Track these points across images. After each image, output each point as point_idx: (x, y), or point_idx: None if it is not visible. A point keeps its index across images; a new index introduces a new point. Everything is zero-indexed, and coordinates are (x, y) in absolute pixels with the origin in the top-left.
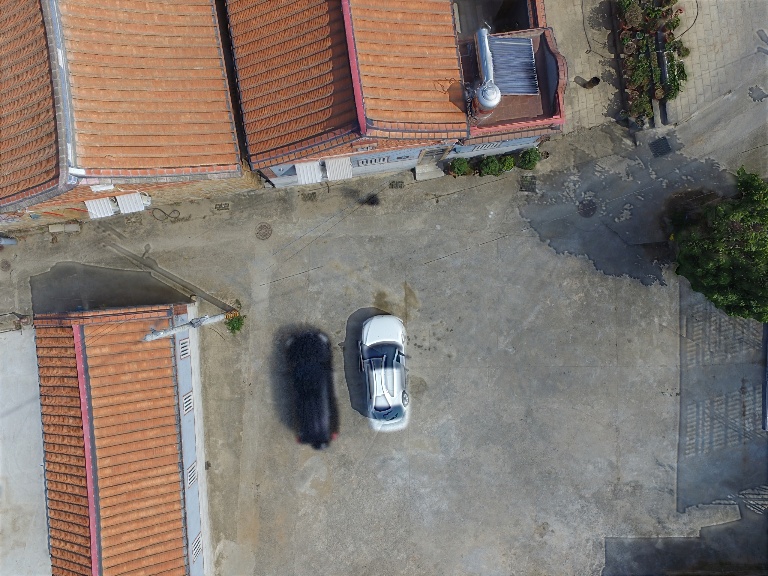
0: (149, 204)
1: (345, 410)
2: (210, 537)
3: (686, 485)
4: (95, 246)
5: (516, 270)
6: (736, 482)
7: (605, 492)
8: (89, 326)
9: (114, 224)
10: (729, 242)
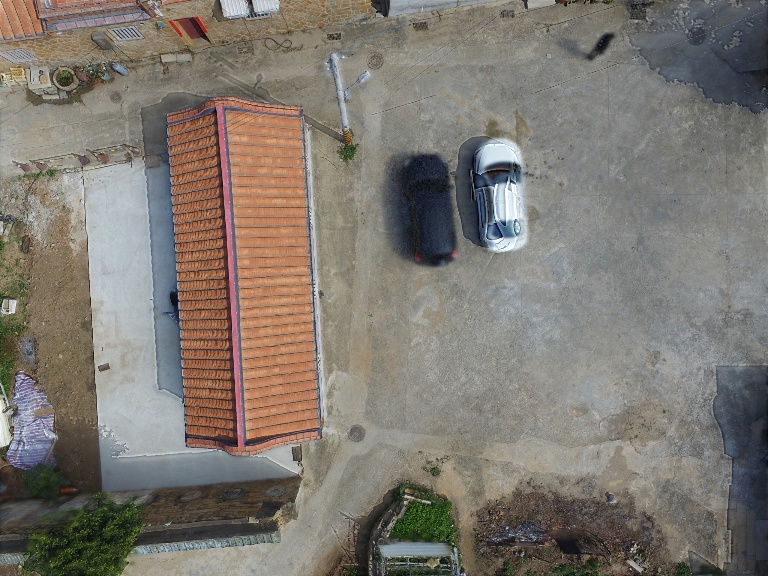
0: (277, 9)
1: (457, 239)
2: (323, 367)
3: None
4: (207, 77)
5: (626, 98)
6: None
7: (716, 320)
8: (230, 112)
9: (226, 54)
10: None
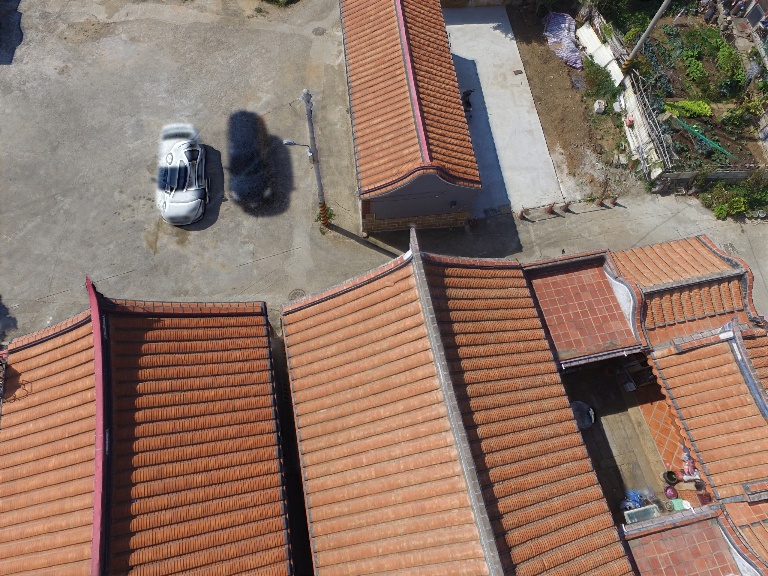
0: None
1: (227, 150)
2: None
3: None
4: None
5: (36, 267)
6: None
7: (0, 94)
8: None
9: None
10: None
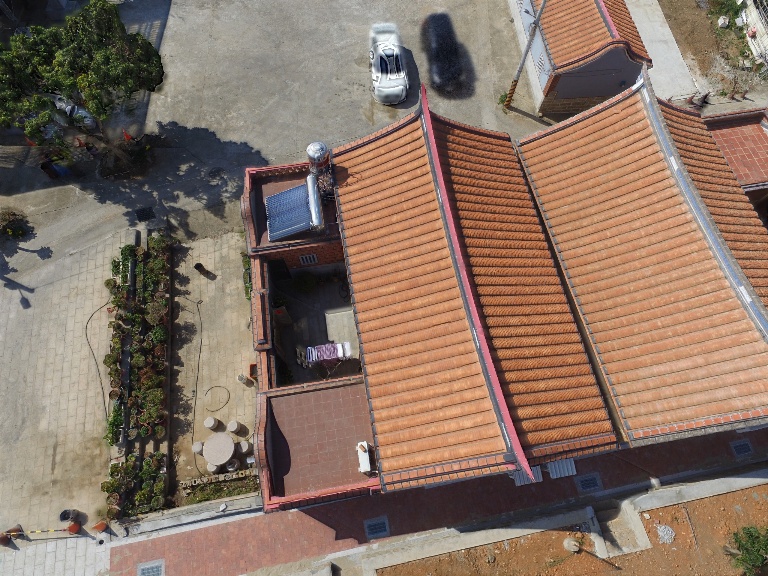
0: None
1: (416, 49)
2: None
3: (163, 7)
4: None
5: (282, 132)
6: (125, 8)
7: (224, 4)
8: None
9: None
10: (129, 60)
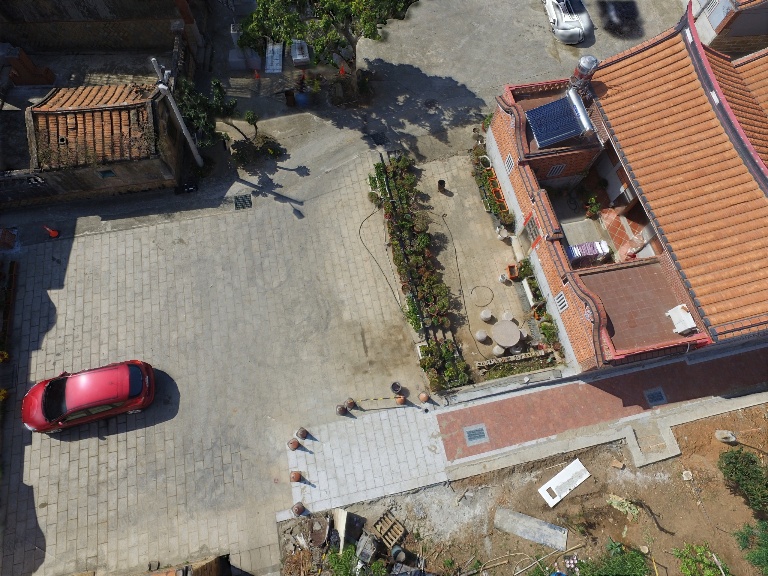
0: None
1: None
2: None
3: None
4: None
5: (480, 68)
6: None
7: None
8: None
9: None
10: None
